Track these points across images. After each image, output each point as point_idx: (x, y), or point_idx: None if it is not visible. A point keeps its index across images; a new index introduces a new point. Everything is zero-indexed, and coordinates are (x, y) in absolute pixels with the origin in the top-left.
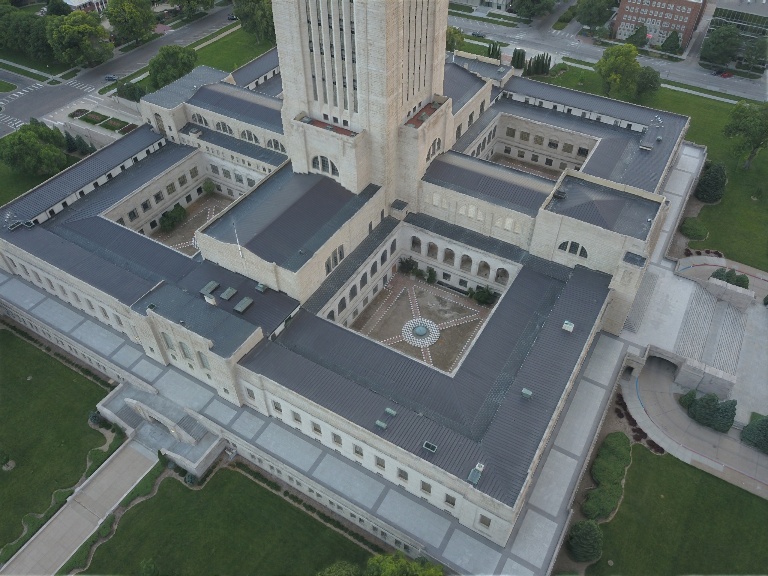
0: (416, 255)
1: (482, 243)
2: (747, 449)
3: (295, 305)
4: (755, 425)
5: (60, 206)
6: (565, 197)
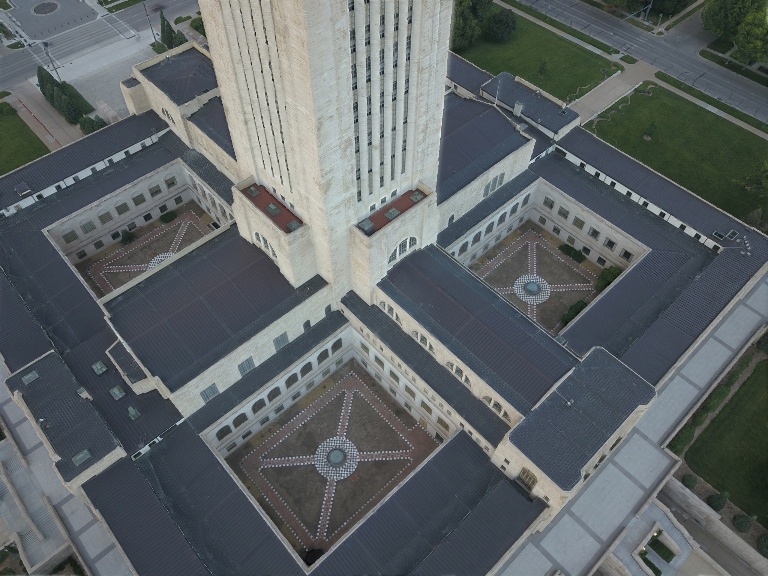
0: None
1: None
2: None
3: None
4: None
5: None
6: None
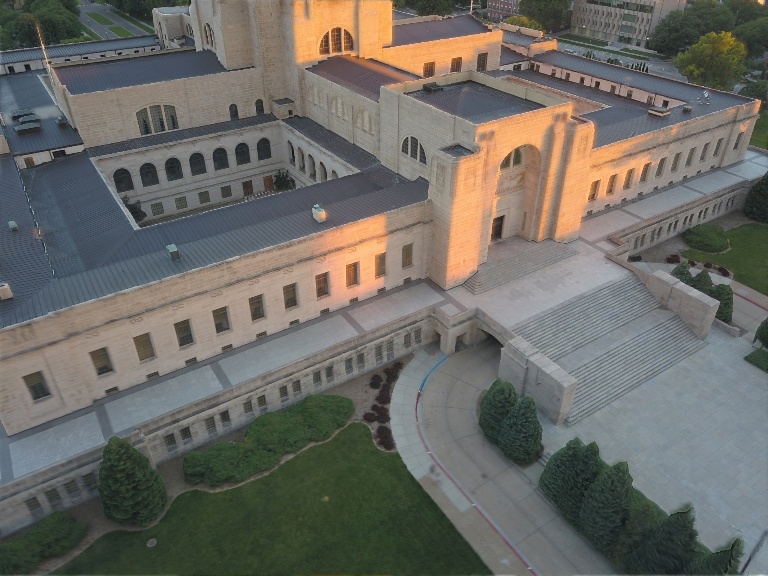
0: (292, 169)
1: (340, 149)
2: (540, 502)
3: (76, 142)
4: (554, 454)
5: (22, 67)
6: (437, 91)
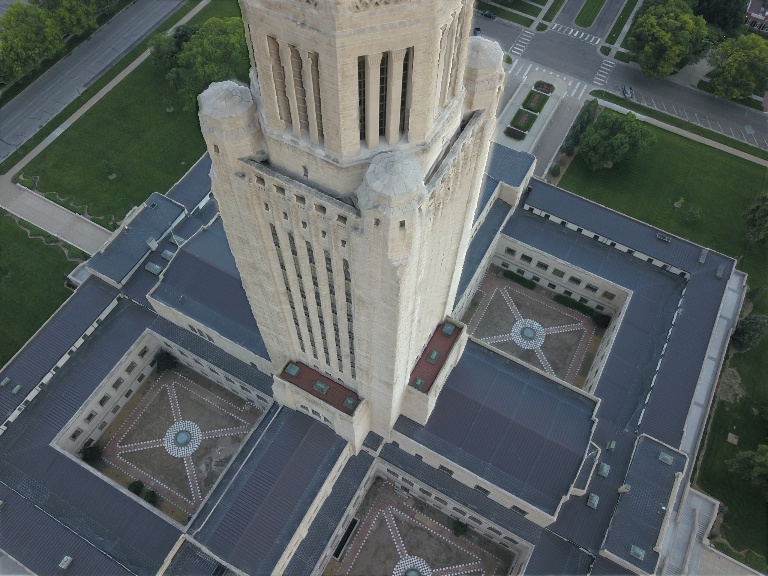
0: None
1: None
2: None
3: None
4: None
5: None
6: None
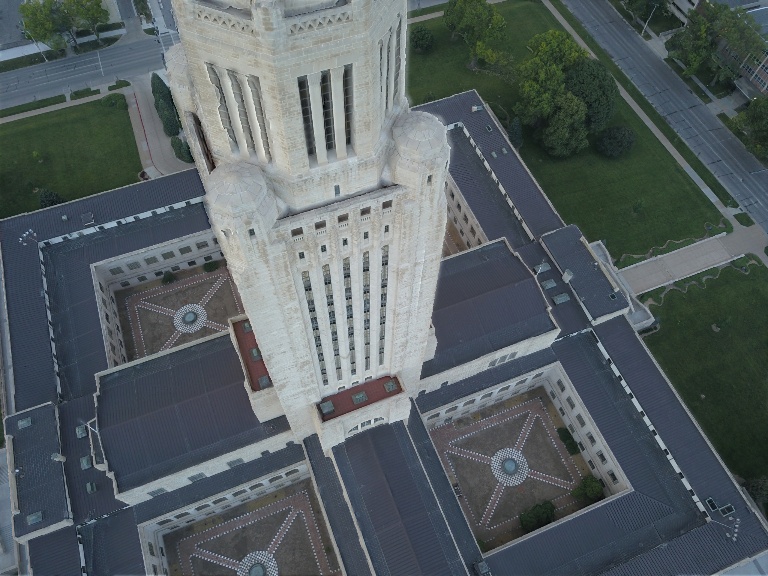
0: None
1: None
2: None
3: None
4: None
5: None
6: None
